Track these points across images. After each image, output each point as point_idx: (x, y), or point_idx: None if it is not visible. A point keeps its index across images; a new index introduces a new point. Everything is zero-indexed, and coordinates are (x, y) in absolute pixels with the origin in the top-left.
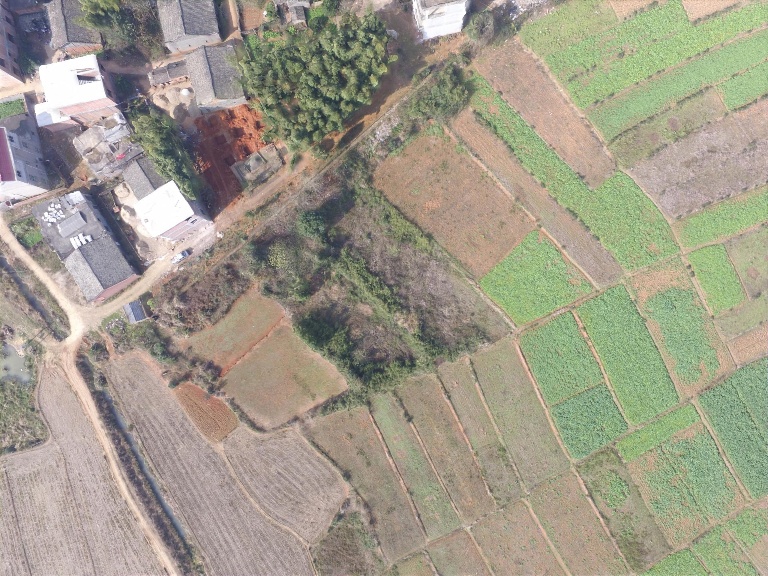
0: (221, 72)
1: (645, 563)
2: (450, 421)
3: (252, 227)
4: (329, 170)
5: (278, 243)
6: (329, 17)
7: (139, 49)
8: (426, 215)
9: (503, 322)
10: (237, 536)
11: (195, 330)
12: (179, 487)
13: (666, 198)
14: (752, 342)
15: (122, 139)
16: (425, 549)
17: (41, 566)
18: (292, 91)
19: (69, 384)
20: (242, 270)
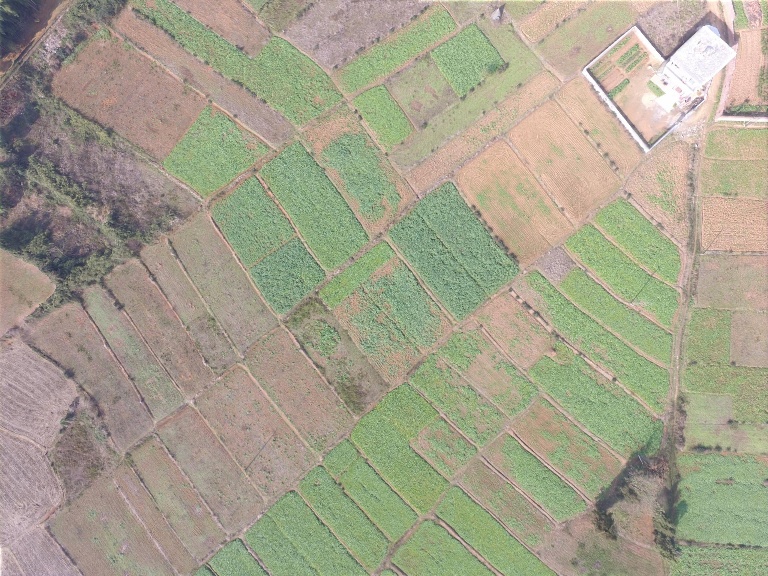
0: None
1: (365, 404)
2: (160, 302)
3: None
4: (6, 87)
5: None
6: None
7: None
8: (105, 112)
9: (192, 197)
10: None
11: None
12: None
13: (321, 52)
14: (428, 170)
15: None
16: (155, 432)
17: None
18: None
19: None
20: None
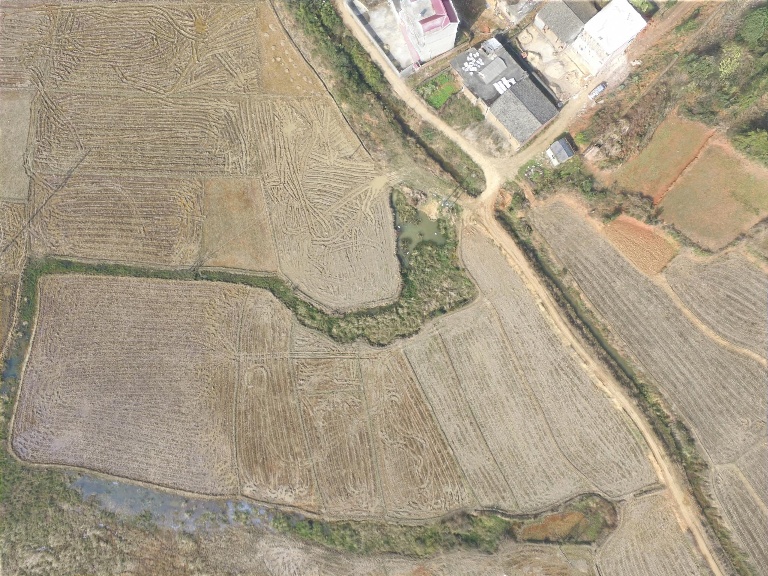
0: None
1: None
2: None
3: (681, 43)
4: None
5: None
6: None
7: None
8: None
9: None
10: (693, 367)
11: None
12: (623, 325)
13: None
14: None
15: None
16: None
17: (490, 424)
18: None
19: (490, 239)
20: (678, 87)
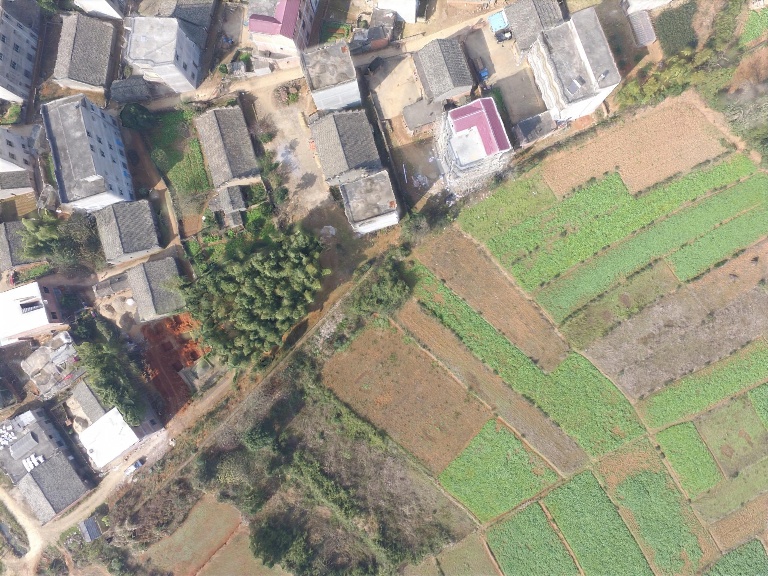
0: (161, 286)
1: None
2: None
3: (202, 438)
4: (276, 373)
5: (226, 461)
6: (266, 219)
7: (83, 264)
8: (378, 410)
9: (467, 518)
10: None
11: (152, 542)
12: None
13: (625, 378)
14: (735, 525)
15: (68, 359)
16: None
17: None
18: (227, 315)
19: None
20: (194, 483)
